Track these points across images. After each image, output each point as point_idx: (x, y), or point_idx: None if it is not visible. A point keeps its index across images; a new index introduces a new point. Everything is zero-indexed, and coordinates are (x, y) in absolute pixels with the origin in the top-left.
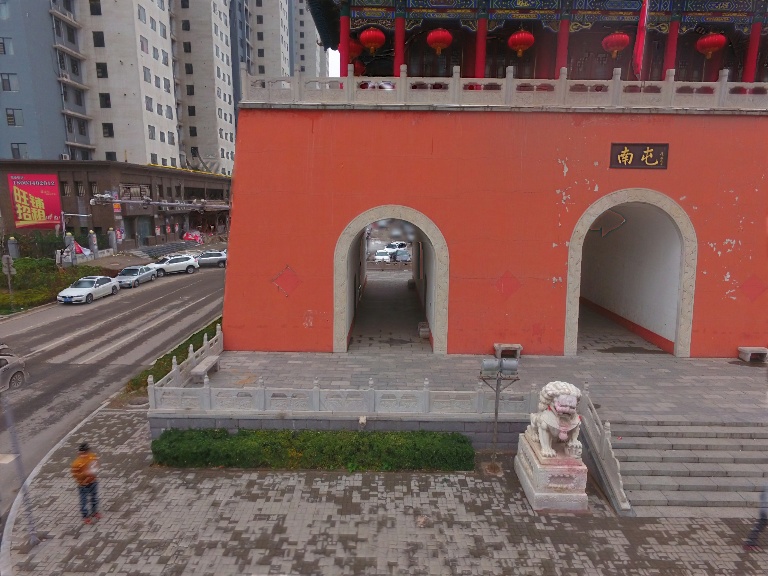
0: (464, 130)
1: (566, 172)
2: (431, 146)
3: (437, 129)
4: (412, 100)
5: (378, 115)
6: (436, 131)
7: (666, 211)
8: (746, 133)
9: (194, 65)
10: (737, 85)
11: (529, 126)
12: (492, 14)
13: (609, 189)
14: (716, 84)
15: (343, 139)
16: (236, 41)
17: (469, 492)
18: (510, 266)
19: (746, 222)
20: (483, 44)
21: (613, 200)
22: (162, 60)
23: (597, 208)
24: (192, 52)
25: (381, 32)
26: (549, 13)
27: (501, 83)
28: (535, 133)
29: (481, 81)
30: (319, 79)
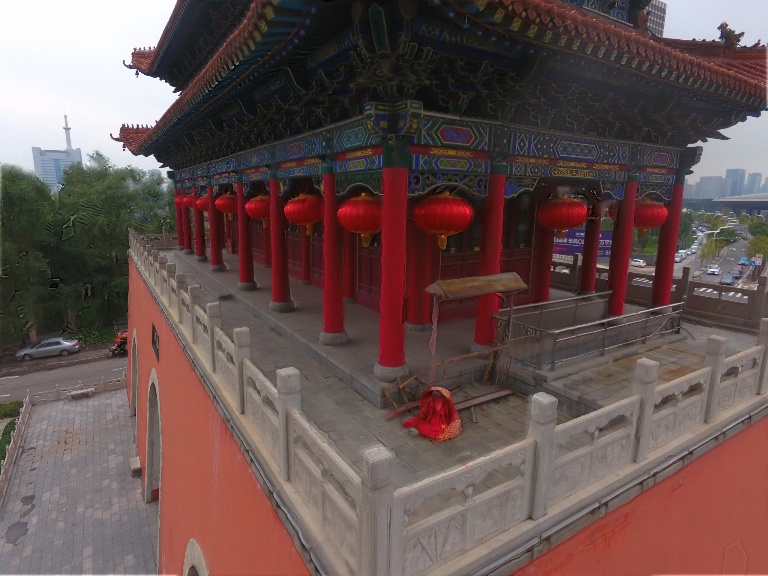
0: None
1: None
2: None
3: None
4: None
5: None
6: None
7: None
8: None
9: None
10: None
11: None
12: None
13: None
14: None
15: None
16: None
17: None
18: None
19: None
20: None
21: None
22: None
23: None
24: None
25: None
26: None
27: None
28: None
29: None
30: (729, 289)
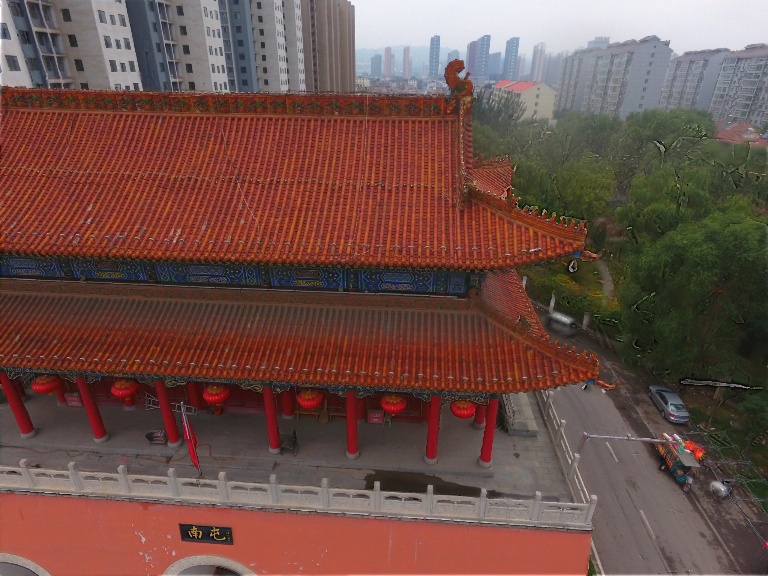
0: (46, 506)
1: (144, 541)
2: (21, 516)
3: (22, 504)
4: None
5: None
6: (21, 505)
7: (239, 573)
8: (301, 524)
9: (84, 61)
10: (287, 488)
11: (102, 507)
12: None
13: (185, 554)
14: (267, 487)
15: None
16: (136, 16)
17: None
18: None
19: None
20: (84, 395)
21: (190, 563)
22: None
23: (177, 567)
24: (79, 46)
25: None
26: None
27: (67, 475)
28: (109, 512)
29: (49, 472)
30: None
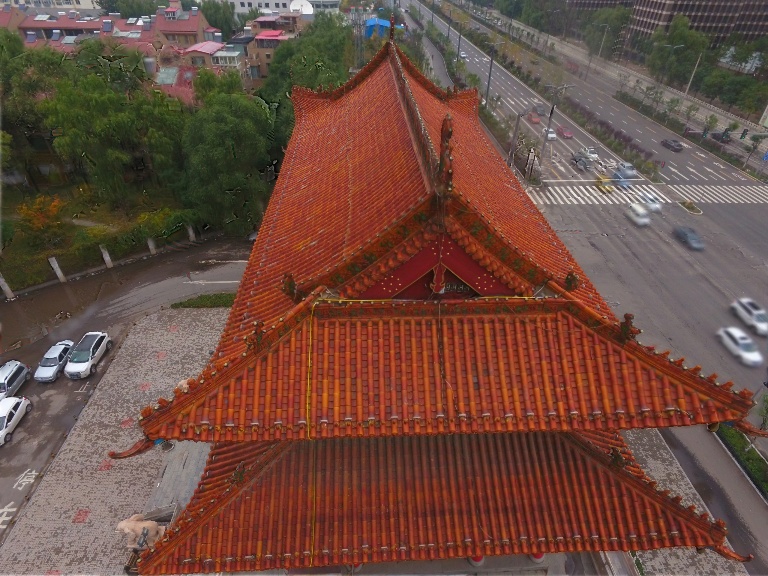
0: None
1: None
2: None
3: None
4: None
5: None
6: None
7: None
8: None
9: None
10: None
11: None
12: None
13: None
14: None
15: None
16: None
17: (646, 554)
18: None
19: None
20: None
21: None
22: None
23: None
24: None
25: None
26: None
27: None
28: None
29: None
30: None
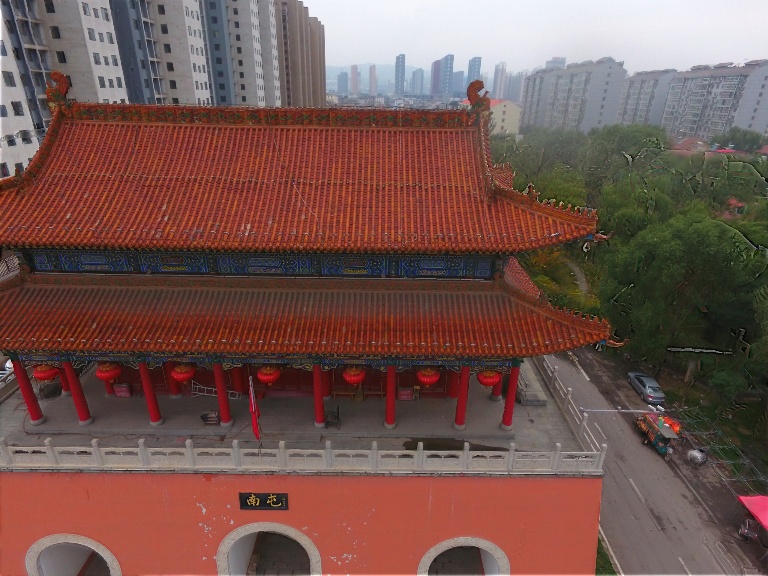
0: (112, 483)
1: (205, 512)
2: (87, 494)
3: (89, 483)
4: (63, 462)
5: (36, 474)
6: (89, 484)
7: (292, 537)
8: (352, 486)
9: (72, 77)
10: (340, 453)
11: (167, 481)
12: (149, 358)
13: (243, 522)
14: (322, 452)
15: (11, 489)
16: (123, 34)
17: None
18: (171, 571)
19: (359, 543)
20: (146, 380)
21: (247, 530)
22: (14, 113)
23: (235, 535)
24: (68, 62)
25: (52, 370)
26: (201, 357)
27: (136, 451)
28: (173, 486)
29: (119, 450)
30: None
